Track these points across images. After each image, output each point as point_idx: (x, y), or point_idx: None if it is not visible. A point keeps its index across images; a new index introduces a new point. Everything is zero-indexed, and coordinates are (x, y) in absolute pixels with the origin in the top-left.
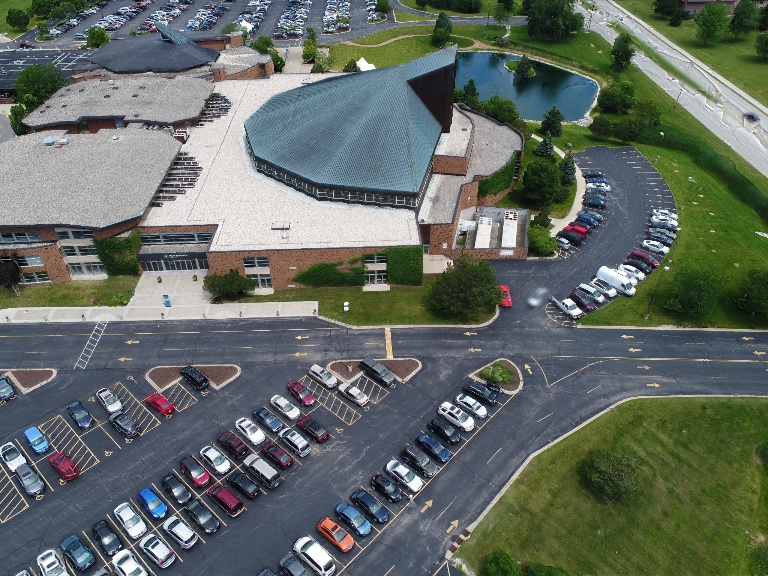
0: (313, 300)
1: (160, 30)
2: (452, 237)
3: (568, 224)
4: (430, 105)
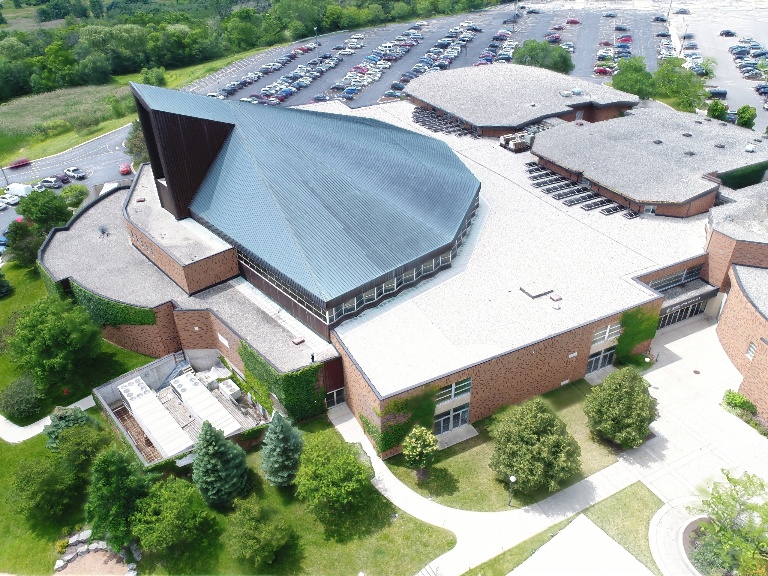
0: None
1: None
2: None
3: None
4: None
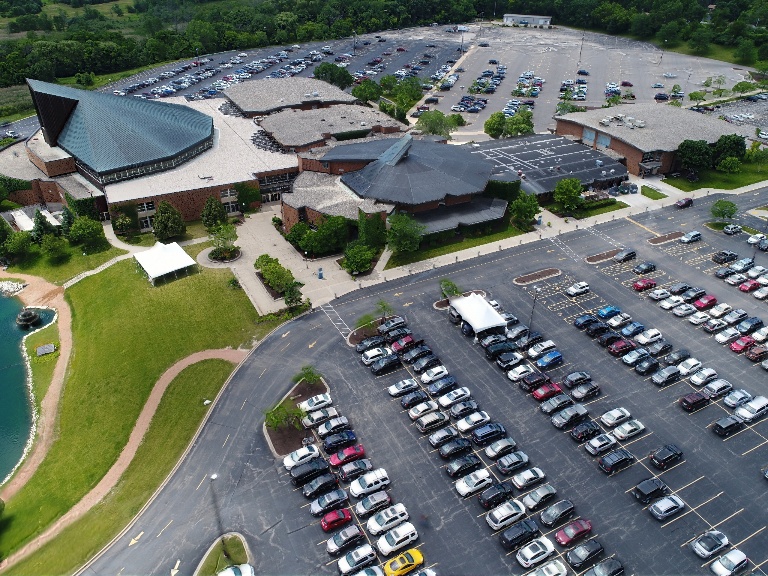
0: None
1: None
2: None
3: None
4: None
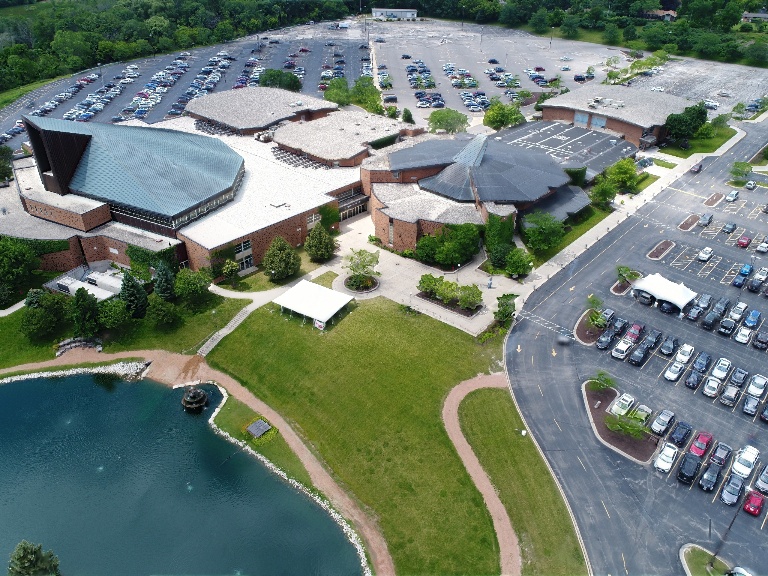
0: None
1: None
2: None
3: None
4: None
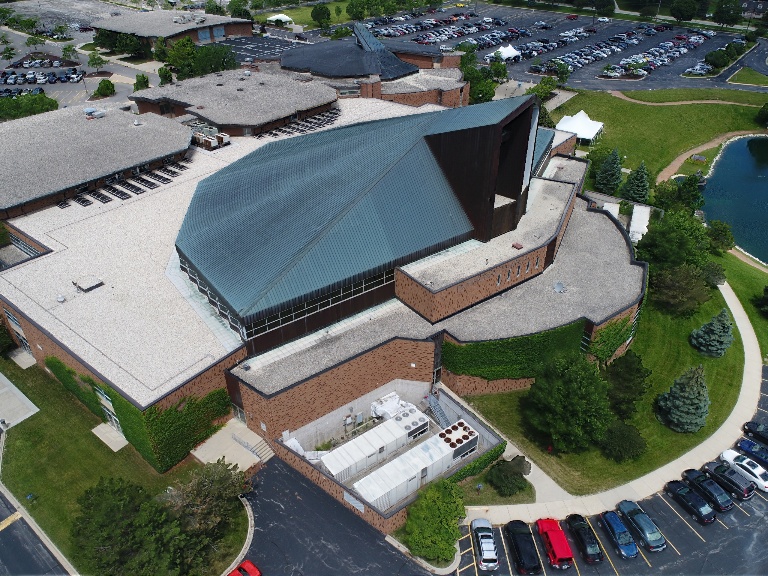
0: (37, 405)
1: (355, 32)
2: (270, 419)
3: (568, 514)
4: (457, 187)
